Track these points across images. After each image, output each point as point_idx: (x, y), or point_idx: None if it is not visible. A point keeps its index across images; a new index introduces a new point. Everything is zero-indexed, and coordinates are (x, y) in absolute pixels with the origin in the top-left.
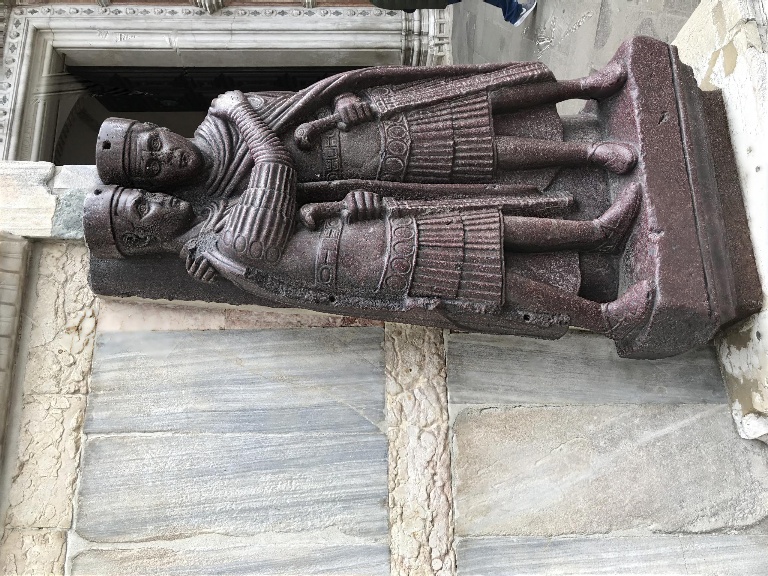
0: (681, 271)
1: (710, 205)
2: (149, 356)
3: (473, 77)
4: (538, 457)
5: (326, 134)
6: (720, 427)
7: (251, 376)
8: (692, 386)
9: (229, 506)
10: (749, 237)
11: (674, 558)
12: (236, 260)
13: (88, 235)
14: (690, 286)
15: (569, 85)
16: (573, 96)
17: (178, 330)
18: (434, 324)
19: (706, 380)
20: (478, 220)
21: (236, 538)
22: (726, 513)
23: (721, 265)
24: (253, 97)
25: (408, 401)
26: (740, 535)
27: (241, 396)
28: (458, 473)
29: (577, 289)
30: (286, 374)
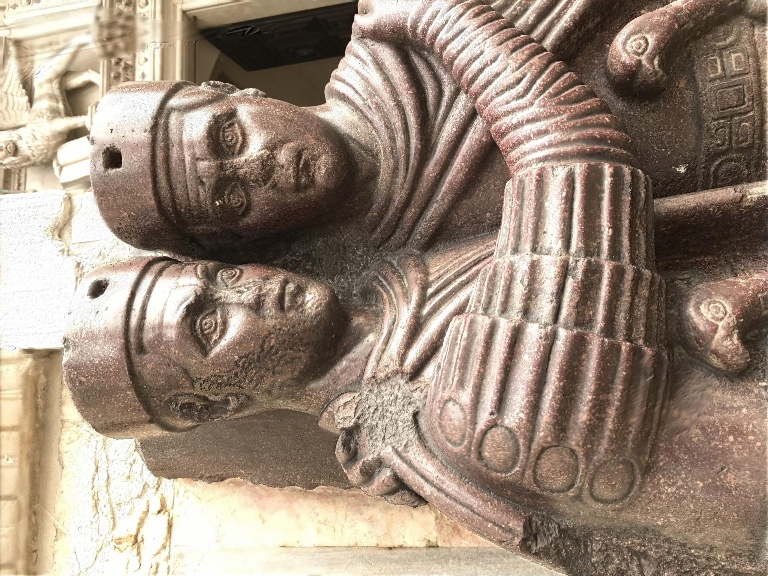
0: None
1: None
2: None
3: None
4: None
5: (708, 39)
6: None
7: None
8: None
9: None
10: None
11: None
12: (485, 487)
13: (83, 408)
14: None
15: None
16: None
17: (335, 547)
18: None
19: None
20: None
21: None
22: None
23: None
24: None
25: None
26: None
27: None
28: None
29: None
30: None
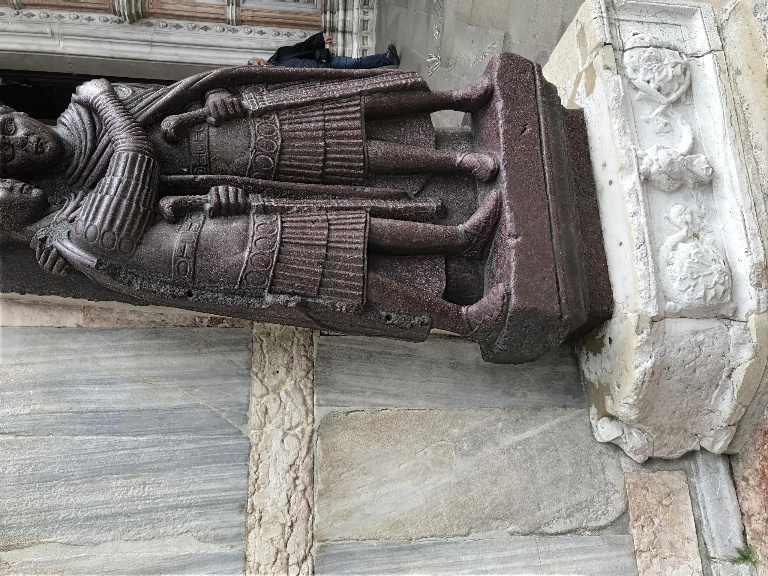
0: (535, 275)
1: (567, 215)
2: None
3: (348, 81)
4: (402, 460)
5: (195, 128)
6: (578, 431)
7: (108, 376)
8: (553, 391)
9: (74, 513)
10: (603, 247)
11: (530, 559)
12: (87, 250)
13: None
14: (543, 290)
15: (442, 96)
16: (446, 107)
17: (30, 326)
18: (297, 323)
19: (567, 386)
20: (344, 220)
21: (80, 547)
22: (581, 514)
23: (575, 272)
24: (121, 87)
25: (273, 403)
26: (593, 536)
27: (95, 397)
28: (320, 477)
29: (441, 292)
30: (146, 374)
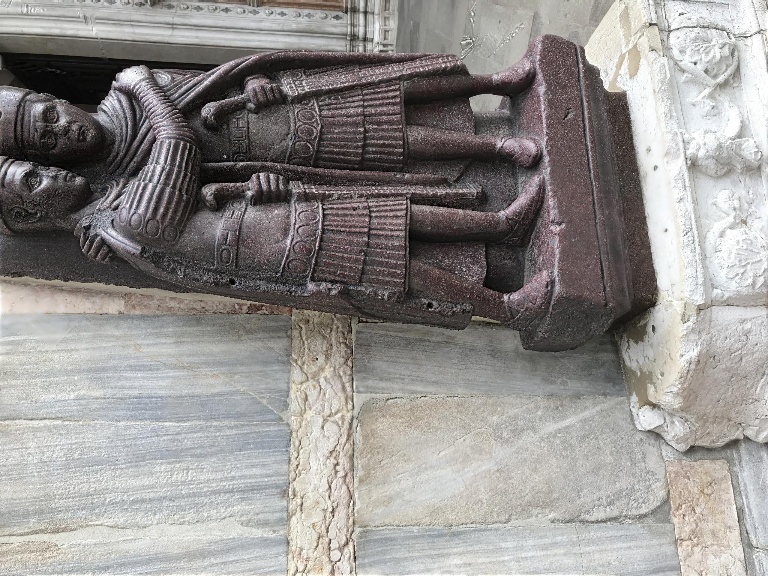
0: (579, 262)
1: (611, 201)
2: (40, 340)
3: (386, 66)
4: (441, 447)
5: (234, 115)
6: (618, 419)
7: (150, 362)
8: (593, 379)
9: (120, 497)
10: (647, 233)
11: (570, 547)
12: (132, 238)
13: None
14: (587, 277)
15: (482, 79)
16: (486, 91)
17: (73, 313)
18: (338, 311)
19: (607, 373)
20: (385, 207)
21: (126, 531)
22: (621, 503)
23: (619, 259)
24: (160, 74)
25: (313, 390)
26: (634, 524)
27: (138, 383)
28: (361, 463)
29: (482, 279)
30: (187, 361)
